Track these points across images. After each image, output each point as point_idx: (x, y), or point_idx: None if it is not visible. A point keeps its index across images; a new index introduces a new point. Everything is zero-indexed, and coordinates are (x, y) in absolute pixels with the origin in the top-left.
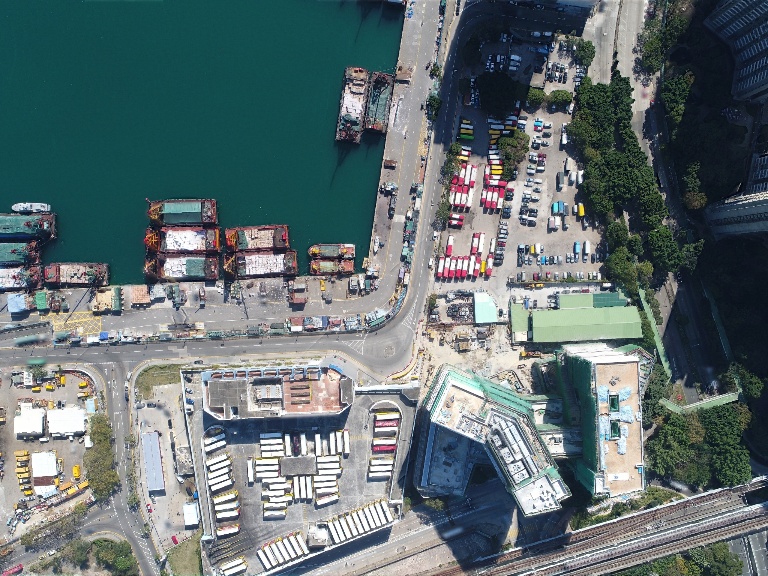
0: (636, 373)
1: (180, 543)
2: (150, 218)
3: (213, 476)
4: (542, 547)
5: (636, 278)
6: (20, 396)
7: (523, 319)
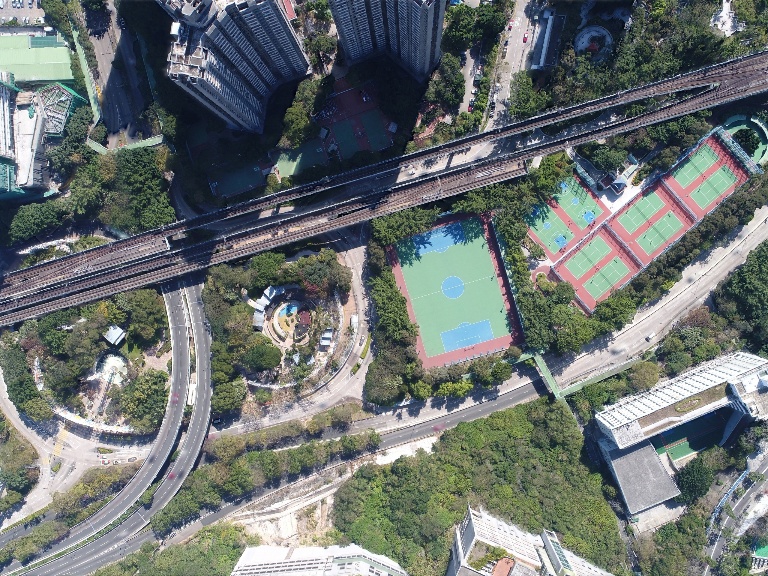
0: None
1: None
2: None
3: None
4: None
5: (65, 17)
6: None
7: None
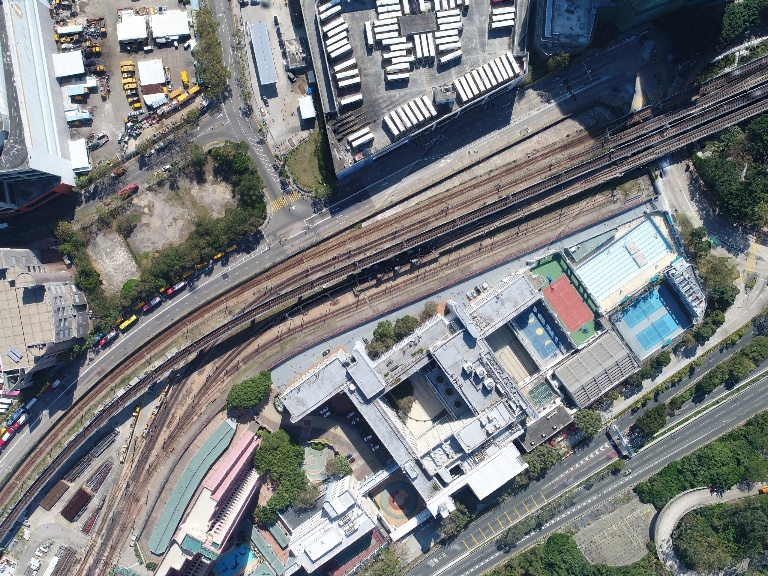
0: None
1: (297, 145)
2: None
3: (331, 42)
4: (671, 103)
5: None
6: (119, 7)
7: None
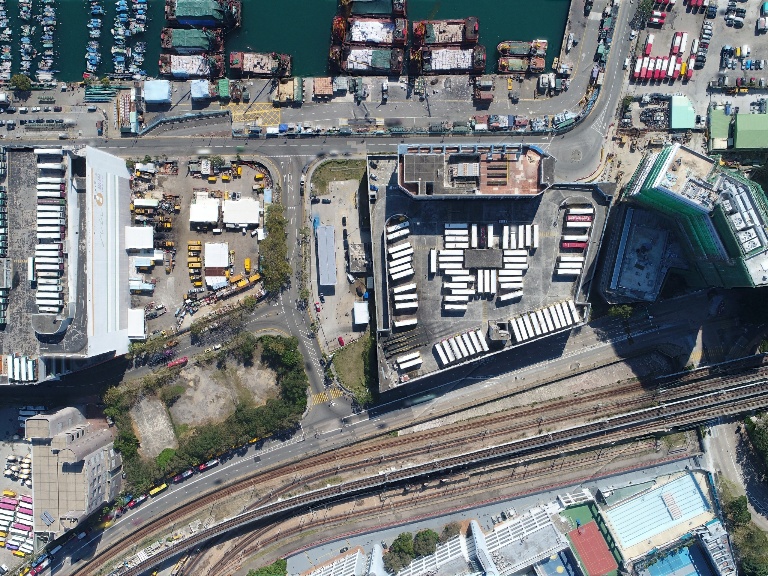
0: None
1: (346, 345)
2: (338, 7)
3: (395, 264)
4: (731, 367)
5: None
6: (195, 186)
7: (724, 125)
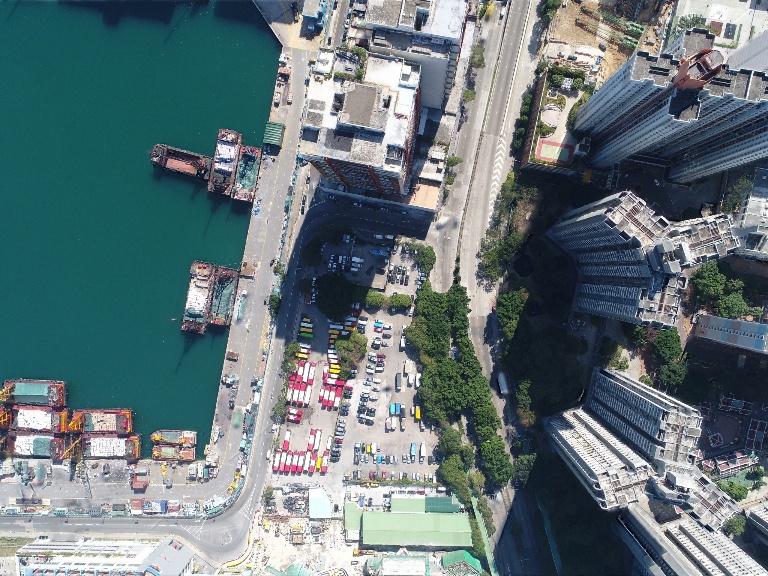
0: None
1: None
2: None
3: None
4: None
5: (467, 487)
6: None
7: (356, 518)
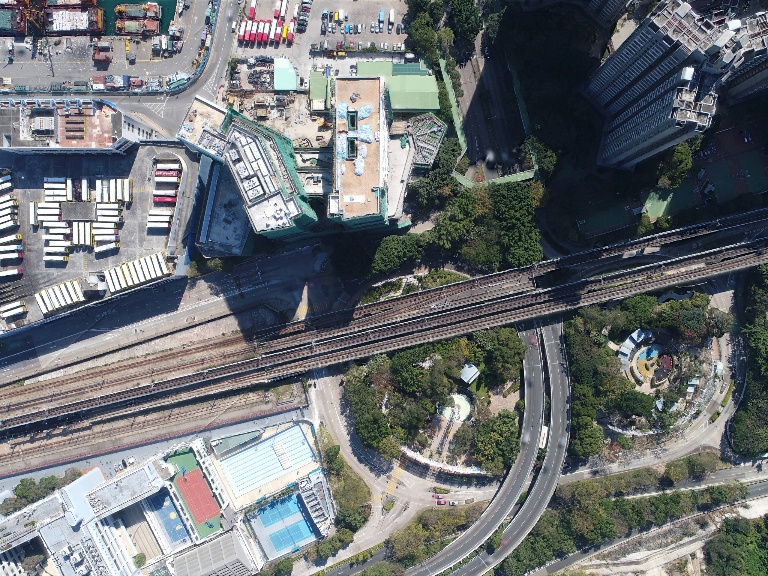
0: (378, 91)
1: None
2: None
3: None
4: (325, 321)
5: (435, 45)
6: None
7: (321, 87)
